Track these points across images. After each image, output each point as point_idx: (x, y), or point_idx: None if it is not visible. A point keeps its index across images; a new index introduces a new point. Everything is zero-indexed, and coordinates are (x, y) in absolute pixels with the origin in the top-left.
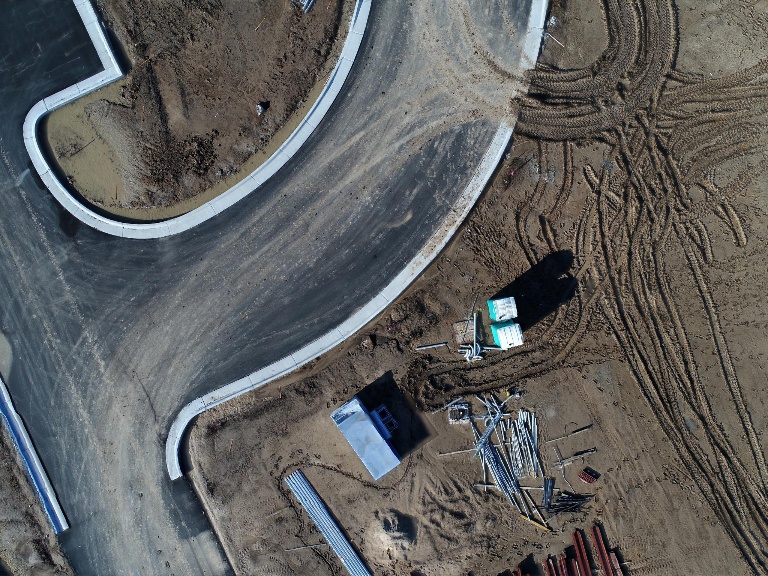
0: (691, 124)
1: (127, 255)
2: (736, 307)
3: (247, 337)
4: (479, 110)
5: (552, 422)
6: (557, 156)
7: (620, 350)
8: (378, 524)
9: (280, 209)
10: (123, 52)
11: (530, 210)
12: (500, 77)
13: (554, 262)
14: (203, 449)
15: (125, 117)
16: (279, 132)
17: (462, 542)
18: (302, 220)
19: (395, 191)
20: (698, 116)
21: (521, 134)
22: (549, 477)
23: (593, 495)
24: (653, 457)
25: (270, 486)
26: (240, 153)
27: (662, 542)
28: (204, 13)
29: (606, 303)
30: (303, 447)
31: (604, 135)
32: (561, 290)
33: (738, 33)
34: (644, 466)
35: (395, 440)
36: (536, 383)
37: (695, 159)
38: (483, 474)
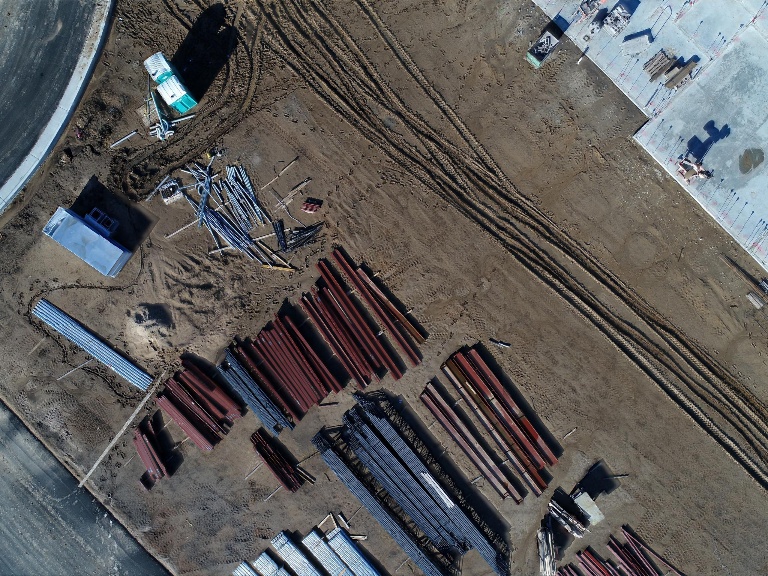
0: None
1: None
2: None
3: None
4: None
5: (260, 168)
6: None
7: (299, 78)
8: (131, 321)
9: None
10: None
11: None
12: None
13: (208, 19)
14: None
15: None
16: None
17: (218, 311)
18: None
19: (38, 7)
20: None
21: None
22: (276, 220)
23: (323, 222)
24: (366, 167)
25: (22, 324)
26: None
27: (403, 243)
28: None
29: (270, 39)
30: (39, 276)
31: None
32: (224, 42)
33: None
34: (360, 178)
35: (121, 238)
36: (232, 137)
37: None
38: (214, 240)
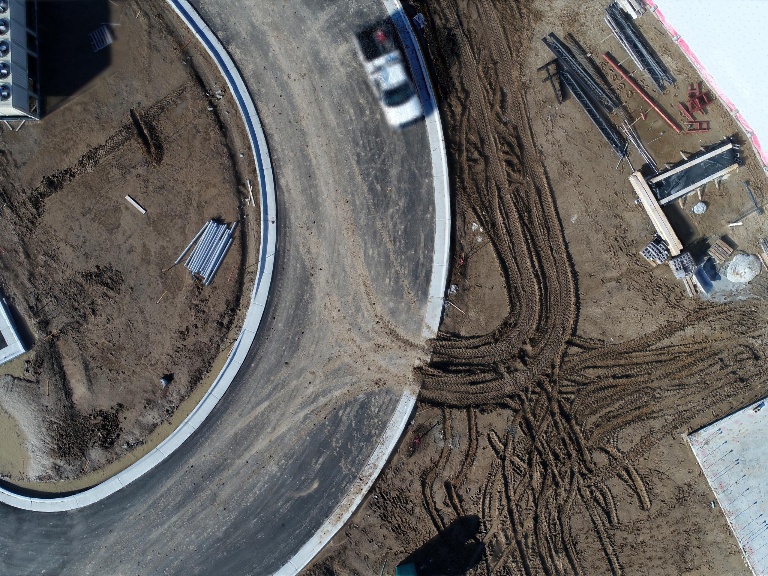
0: (593, 389)
1: (36, 528)
2: (642, 568)
3: None
4: (382, 379)
5: None
6: (461, 422)
7: None
8: None
9: (187, 480)
10: (26, 327)
11: (436, 476)
12: (402, 346)
13: (461, 527)
14: None
15: (30, 392)
16: (184, 403)
17: None
18: (209, 490)
19: (301, 460)
20: (600, 381)
21: (425, 401)
22: None
23: None
24: None
25: None
26: (146, 425)
27: None
28: (105, 288)
29: (513, 566)
30: None
31: (507, 401)
32: (468, 555)
33: (638, 298)
34: None
35: None
36: None
37: (598, 424)
38: None
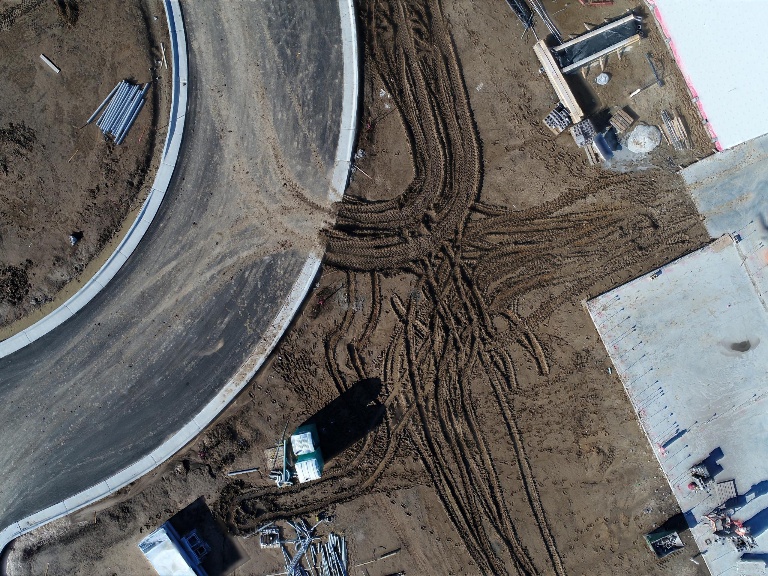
0: (495, 255)
1: None
2: (540, 434)
3: (62, 463)
4: (288, 241)
5: (361, 546)
6: (365, 286)
7: (427, 476)
8: None
9: (94, 337)
10: None
11: (339, 338)
12: (309, 208)
13: (363, 389)
14: (20, 573)
15: None
16: (93, 261)
17: None
18: (116, 348)
19: (207, 320)
20: (502, 247)
21: (330, 264)
22: None
23: None
24: None
25: None
26: (54, 282)
27: None
28: (18, 145)
29: (414, 429)
30: (117, 571)
31: (411, 265)
32: (369, 417)
33: (540, 166)
34: None
35: (207, 564)
36: (345, 508)
37: (499, 289)
38: None
